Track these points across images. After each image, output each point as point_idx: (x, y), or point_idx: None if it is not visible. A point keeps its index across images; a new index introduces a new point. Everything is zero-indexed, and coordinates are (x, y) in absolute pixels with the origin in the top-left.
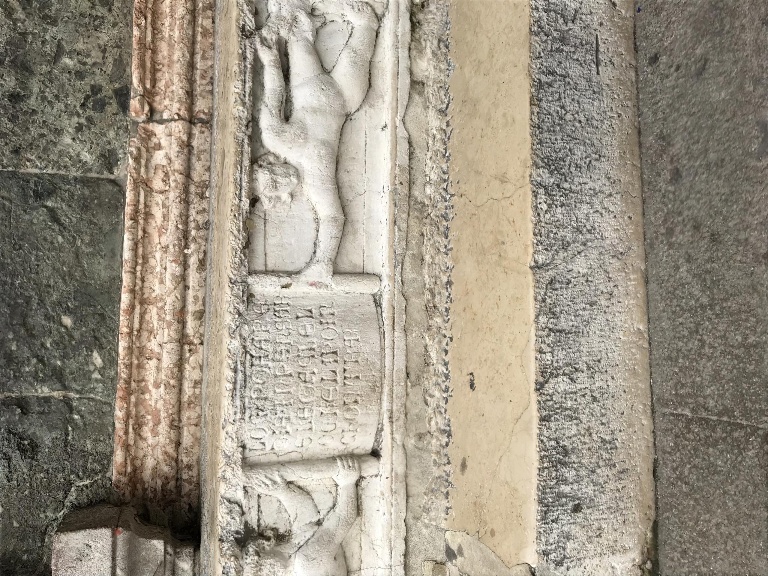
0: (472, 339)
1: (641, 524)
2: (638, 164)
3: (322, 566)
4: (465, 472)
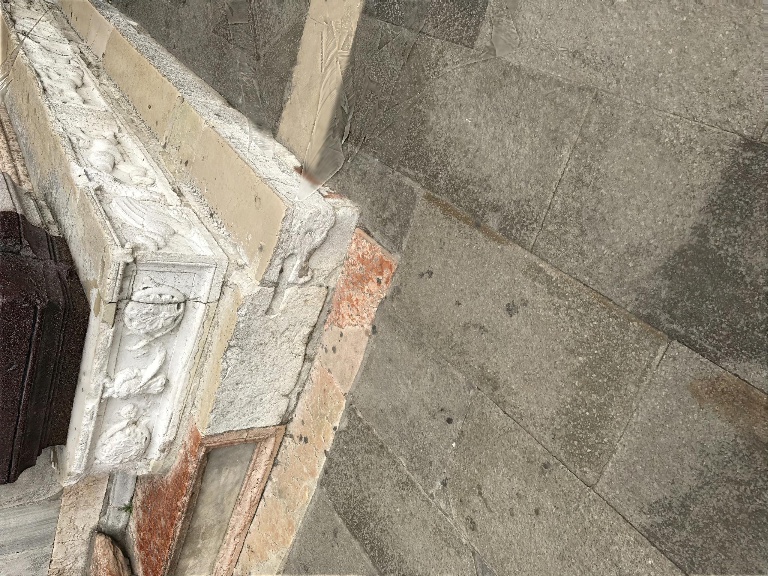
0: None
1: None
2: (182, 63)
3: (105, 140)
4: None
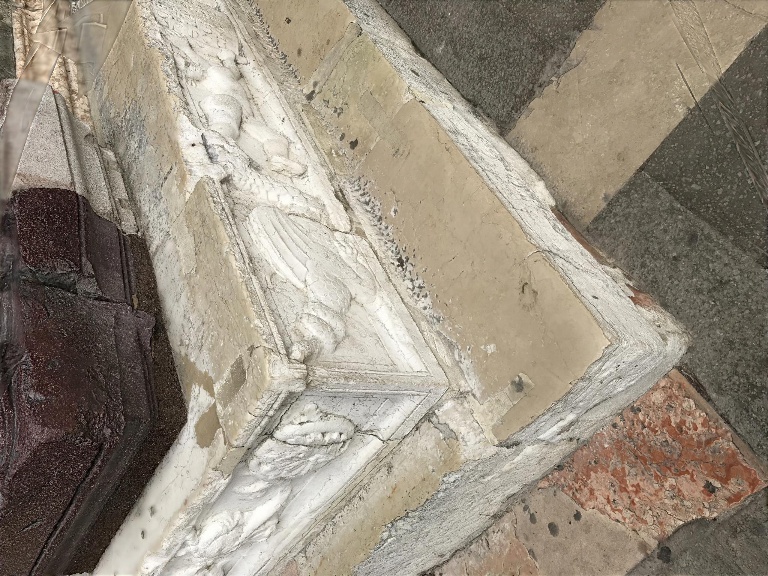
0: (280, 7)
1: (405, 38)
2: None
3: (227, 72)
4: (301, 52)
